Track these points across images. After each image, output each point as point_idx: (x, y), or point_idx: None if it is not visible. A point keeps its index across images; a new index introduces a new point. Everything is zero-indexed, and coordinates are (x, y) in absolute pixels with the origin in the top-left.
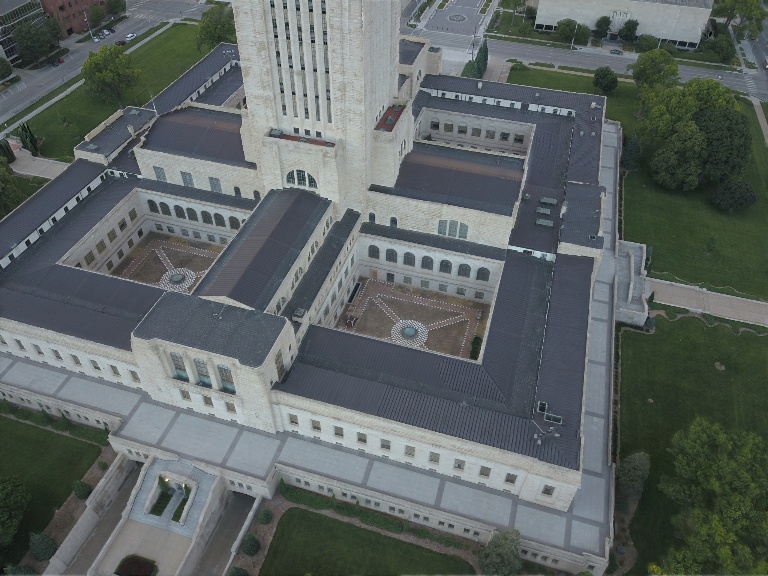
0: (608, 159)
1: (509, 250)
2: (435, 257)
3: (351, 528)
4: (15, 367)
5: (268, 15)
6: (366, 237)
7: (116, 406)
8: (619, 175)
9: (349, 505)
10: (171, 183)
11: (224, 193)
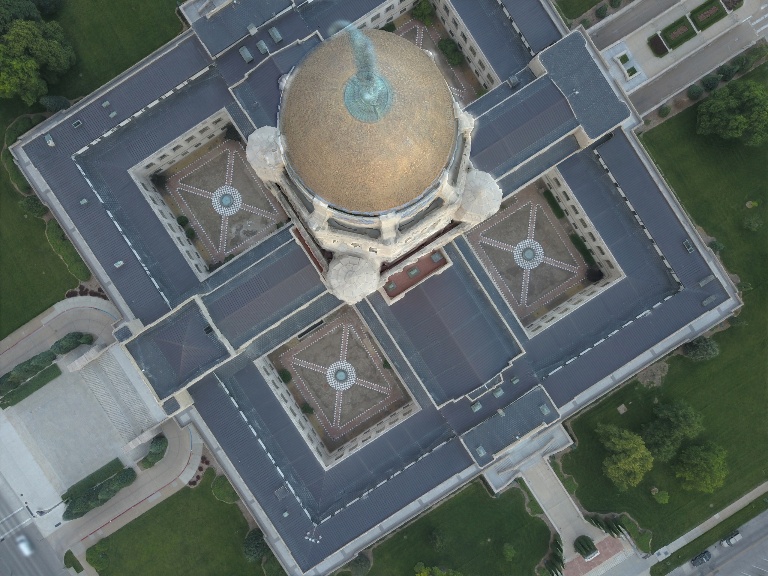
0: None
1: None
2: None
3: None
4: None
5: None
6: None
7: None
8: None
9: None
10: None
11: None
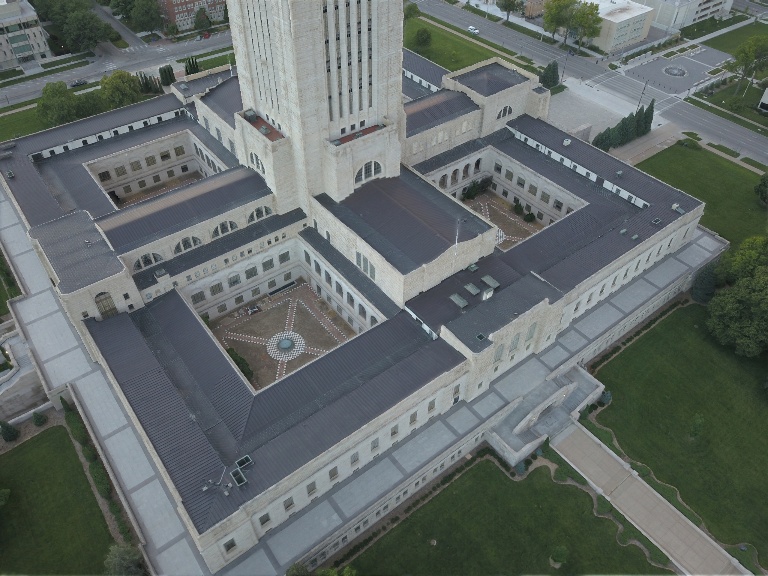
0: (665, 276)
1: (405, 311)
2: (342, 286)
3: (79, 468)
4: (15, 227)
5: (244, 1)
6: (300, 240)
7: (34, 284)
8: (675, 301)
9: (93, 450)
10: (212, 135)
11: (237, 157)
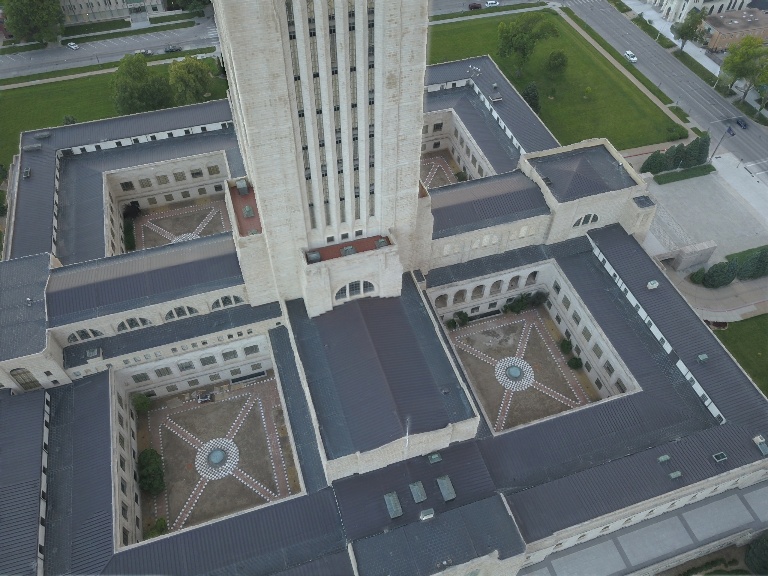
0: (713, 523)
1: (332, 489)
2: None
3: None
4: None
5: None
6: (267, 341)
7: None
8: (718, 557)
9: None
10: None
11: None
